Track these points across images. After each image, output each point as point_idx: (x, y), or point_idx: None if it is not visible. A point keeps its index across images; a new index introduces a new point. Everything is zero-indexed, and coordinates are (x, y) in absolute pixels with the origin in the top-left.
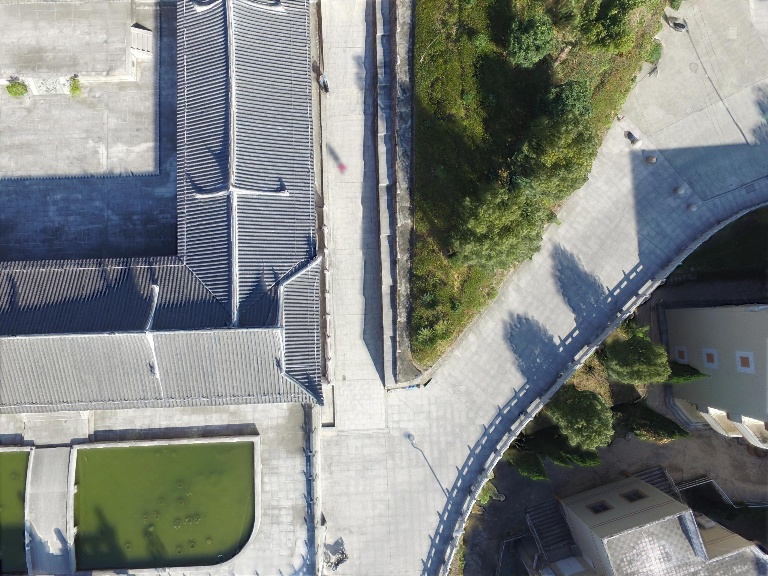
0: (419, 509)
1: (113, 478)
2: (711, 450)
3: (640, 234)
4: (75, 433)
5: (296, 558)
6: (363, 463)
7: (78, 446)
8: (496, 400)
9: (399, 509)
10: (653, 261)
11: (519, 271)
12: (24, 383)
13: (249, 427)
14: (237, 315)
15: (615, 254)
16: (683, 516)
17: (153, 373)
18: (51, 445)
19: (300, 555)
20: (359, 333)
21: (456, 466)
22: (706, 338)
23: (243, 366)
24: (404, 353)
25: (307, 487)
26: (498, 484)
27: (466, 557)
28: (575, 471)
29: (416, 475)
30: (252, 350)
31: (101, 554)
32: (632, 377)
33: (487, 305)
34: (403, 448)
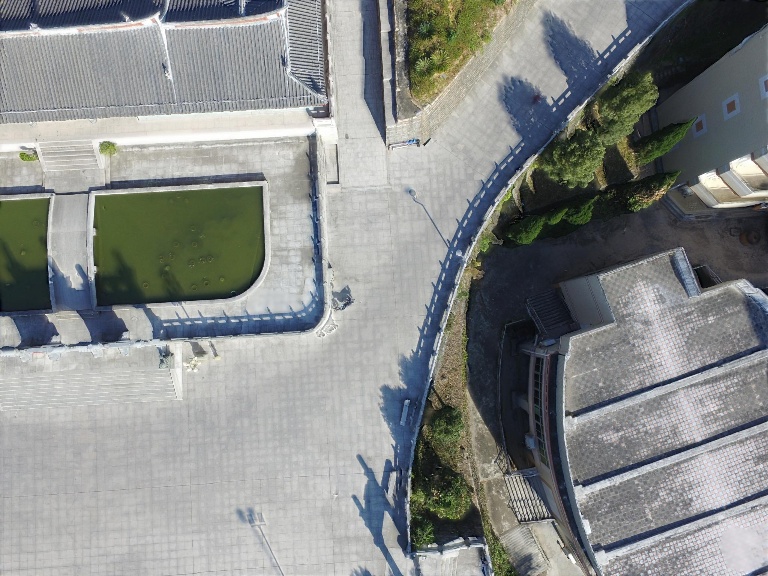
0: (422, 259)
1: (130, 222)
2: (704, 241)
3: (628, 1)
4: (93, 182)
5: (305, 295)
6: (367, 217)
7: (96, 192)
8: (493, 157)
9: (402, 259)
10: (641, 26)
11: (512, 37)
12: (46, 86)
13: (257, 176)
14: (244, 12)
15: (604, 20)
16: (676, 260)
17: (166, 71)
18: (70, 193)
19: (309, 292)
20: (360, 93)
21: (456, 218)
22: (695, 107)
23: (251, 66)
24: (403, 91)
25: (314, 230)
26: (498, 276)
27: (469, 345)
28: (573, 263)
29: (418, 227)
30: (259, 48)
31: (120, 292)
32: (622, 108)
33: (481, 51)
34: (405, 203)
